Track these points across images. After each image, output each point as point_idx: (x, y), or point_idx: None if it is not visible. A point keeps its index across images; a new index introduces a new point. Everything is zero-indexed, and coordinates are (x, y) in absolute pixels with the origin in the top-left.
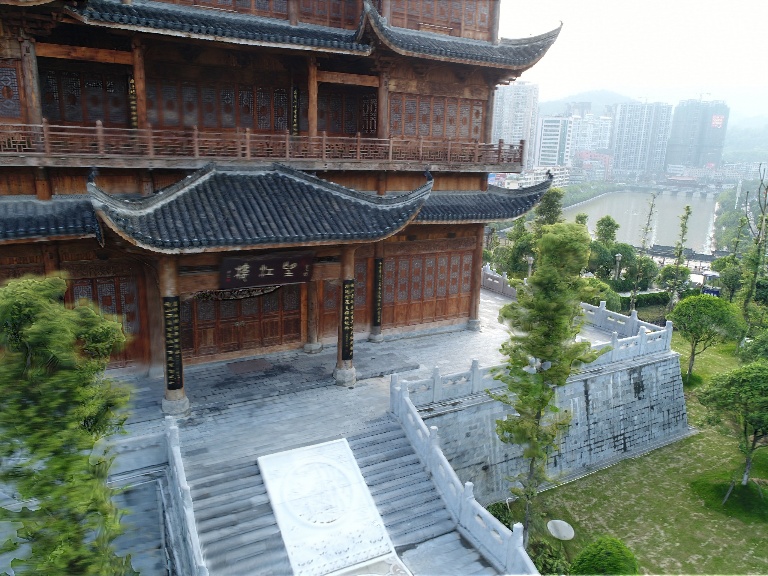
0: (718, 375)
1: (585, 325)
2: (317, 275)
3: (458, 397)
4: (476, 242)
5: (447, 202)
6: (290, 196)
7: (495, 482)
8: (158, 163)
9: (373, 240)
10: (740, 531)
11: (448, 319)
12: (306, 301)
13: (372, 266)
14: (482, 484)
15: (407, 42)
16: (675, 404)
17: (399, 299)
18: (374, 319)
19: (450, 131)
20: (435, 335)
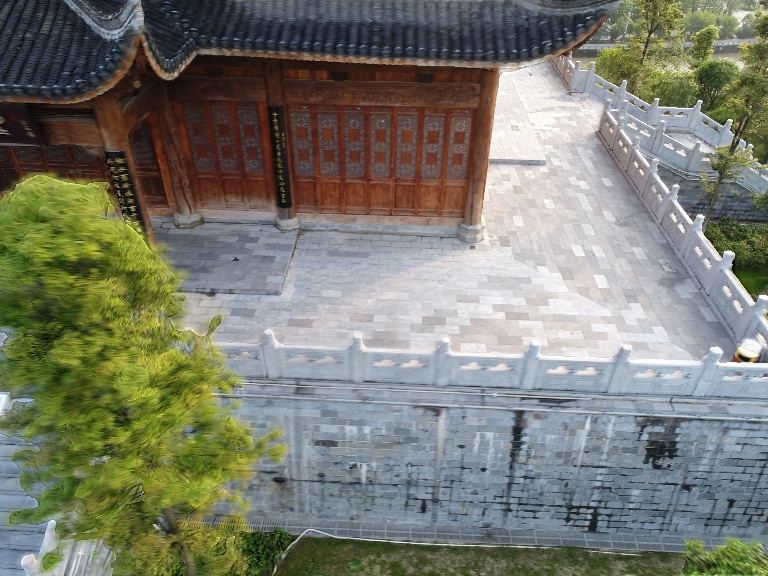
0: (745, 553)
1: (687, 281)
2: (61, 136)
3: (239, 377)
4: (479, 95)
5: (392, 15)
6: None
7: (297, 501)
8: None
9: (63, 100)
10: None
11: (420, 215)
12: (164, 155)
13: (266, 116)
14: (272, 497)
15: None
16: (756, 495)
17: (324, 173)
18: (278, 197)
19: None
20: (392, 236)
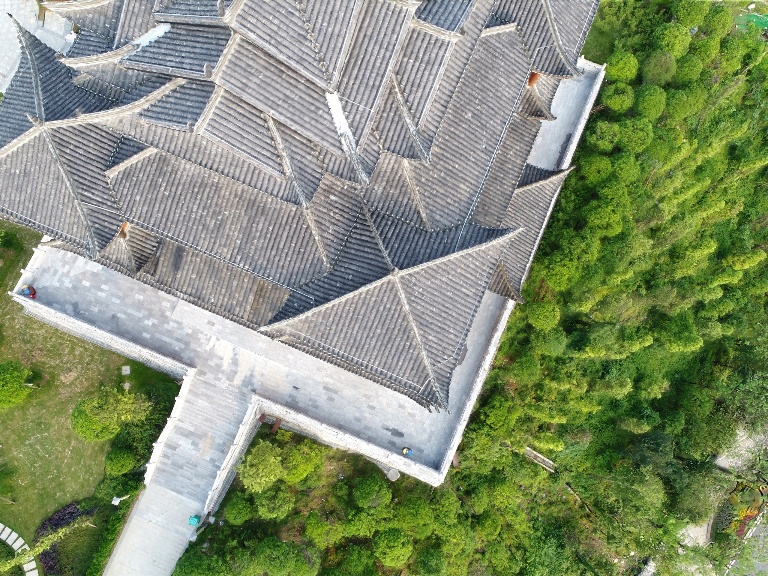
0: None
1: (73, 313)
2: None
3: None
4: None
5: None
6: None
7: None
8: None
9: None
10: (3, 225)
11: None
12: None
13: None
14: None
15: None
16: None
17: None
18: None
19: None
20: None
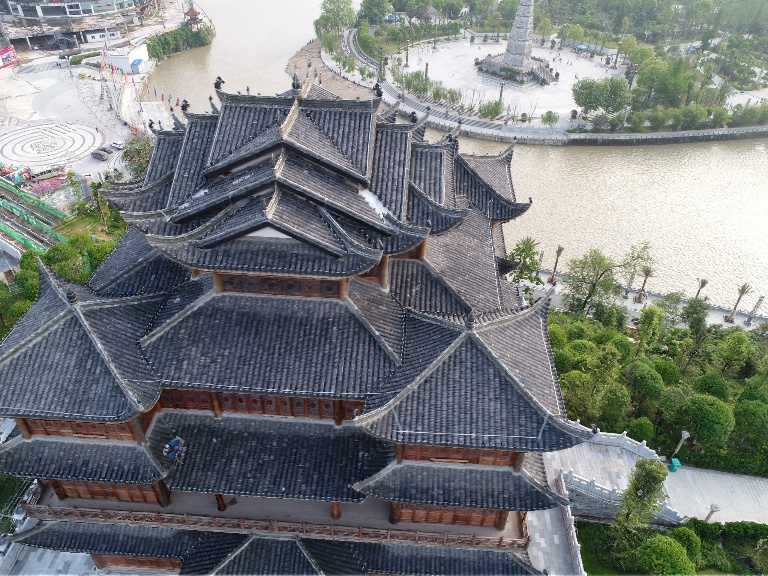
0: None
1: None
2: None
3: None
4: None
5: (449, 552)
6: (292, 572)
7: None
8: (220, 530)
9: None
10: None
11: None
12: None
13: None
14: None
15: (407, 486)
16: None
17: None
18: None
19: (463, 510)
20: None
